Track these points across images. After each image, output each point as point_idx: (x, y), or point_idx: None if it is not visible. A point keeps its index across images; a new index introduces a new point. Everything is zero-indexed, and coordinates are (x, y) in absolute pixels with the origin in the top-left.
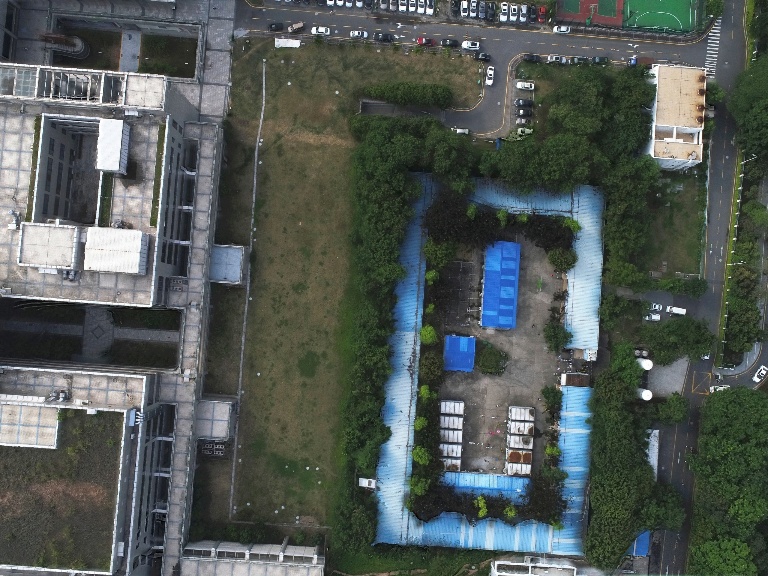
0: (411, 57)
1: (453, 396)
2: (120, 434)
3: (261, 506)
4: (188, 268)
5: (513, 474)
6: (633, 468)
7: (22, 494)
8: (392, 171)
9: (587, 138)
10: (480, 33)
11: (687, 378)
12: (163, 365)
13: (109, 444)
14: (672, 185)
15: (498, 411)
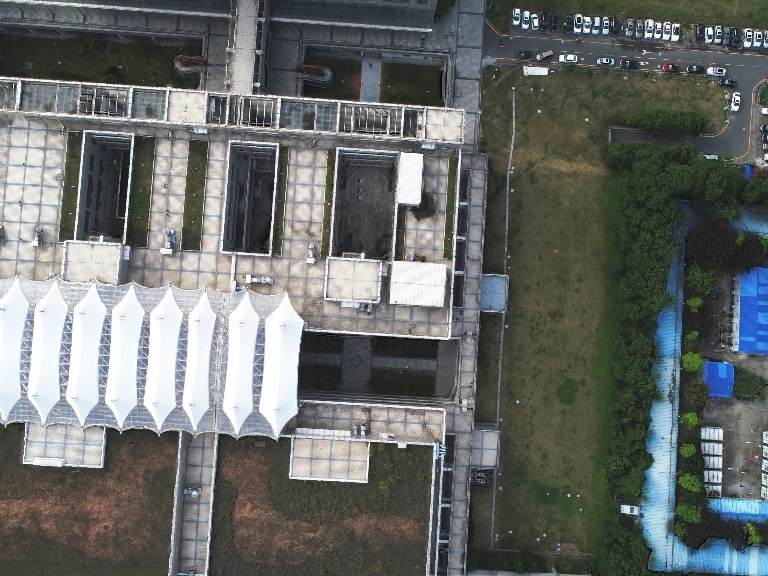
0: (657, 84)
1: (709, 422)
2: (429, 467)
3: (523, 534)
4: (463, 298)
5: None
6: None
7: (334, 528)
8: (666, 200)
9: None
10: (724, 59)
11: None
12: (426, 394)
13: (420, 478)
14: None
15: (752, 436)
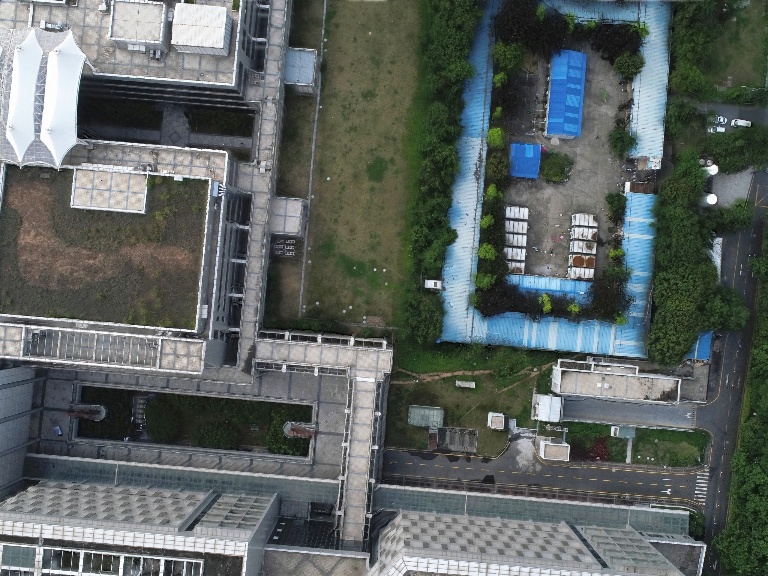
0: None
1: (517, 203)
2: (205, 201)
3: (330, 305)
4: (265, 63)
5: (576, 278)
6: (698, 264)
7: (113, 256)
8: None
9: None
10: None
11: (751, 191)
12: None
13: (195, 209)
14: (739, 1)
15: (561, 220)
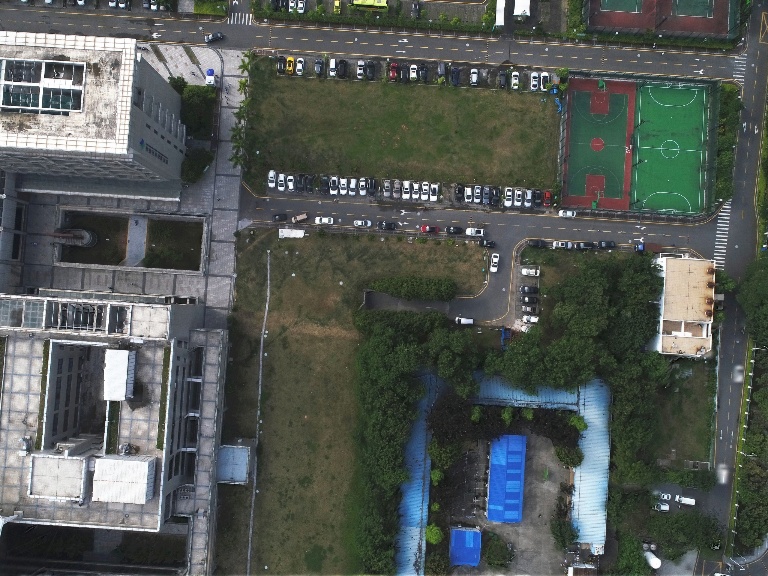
0: (415, 245)
1: None
2: None
3: None
4: (195, 476)
5: None
6: None
7: None
8: (396, 380)
9: (593, 341)
10: (484, 218)
11: (697, 567)
12: (172, 561)
13: None
14: (681, 371)
15: None
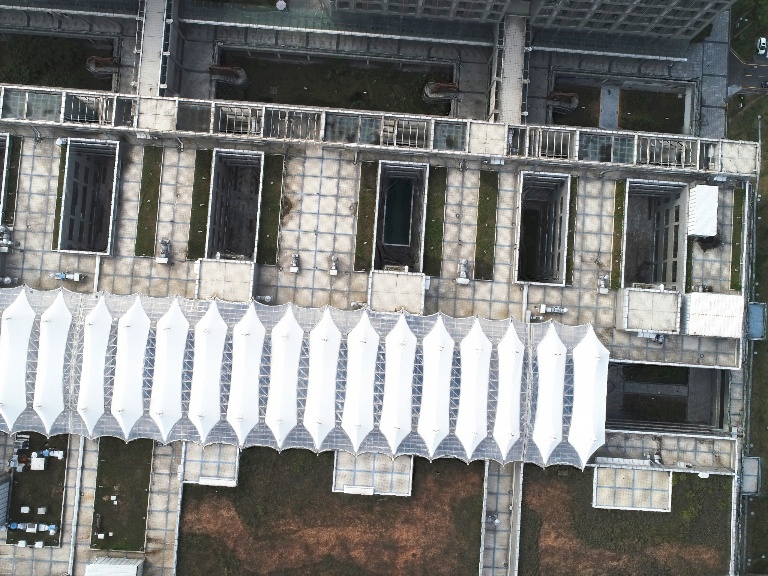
0: None
1: None
2: (728, 497)
3: None
4: None
5: None
6: None
7: (637, 557)
8: None
9: None
10: None
11: None
12: (683, 420)
13: (722, 507)
14: None
15: None
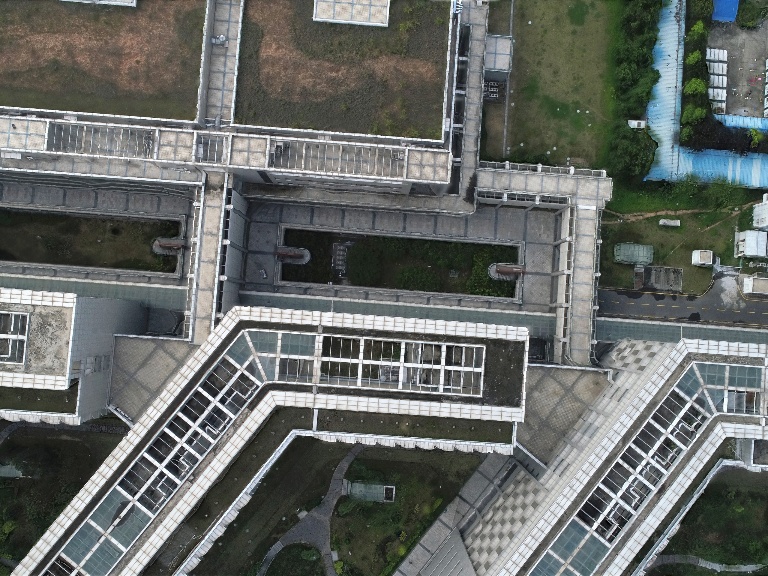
0: None
1: (714, 48)
2: (446, 15)
3: (534, 147)
4: None
5: None
6: None
7: (356, 69)
8: None
9: None
10: None
11: None
12: None
13: (438, 21)
14: None
15: (755, 65)
